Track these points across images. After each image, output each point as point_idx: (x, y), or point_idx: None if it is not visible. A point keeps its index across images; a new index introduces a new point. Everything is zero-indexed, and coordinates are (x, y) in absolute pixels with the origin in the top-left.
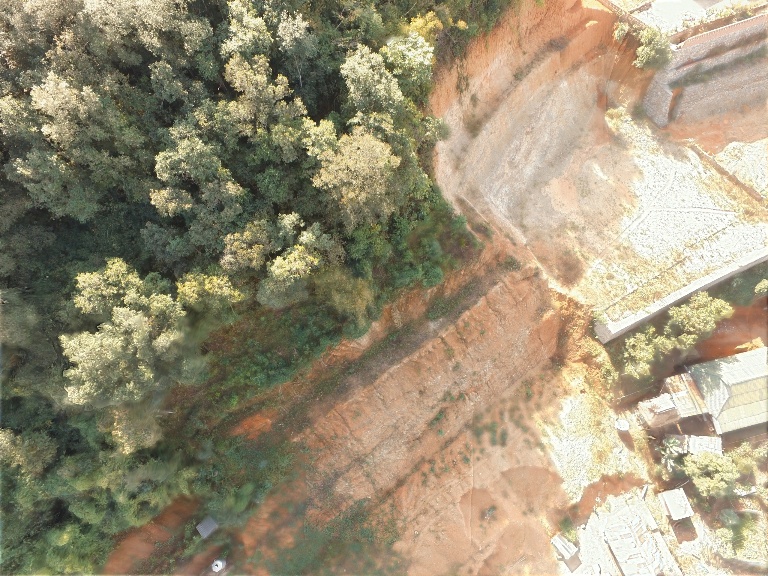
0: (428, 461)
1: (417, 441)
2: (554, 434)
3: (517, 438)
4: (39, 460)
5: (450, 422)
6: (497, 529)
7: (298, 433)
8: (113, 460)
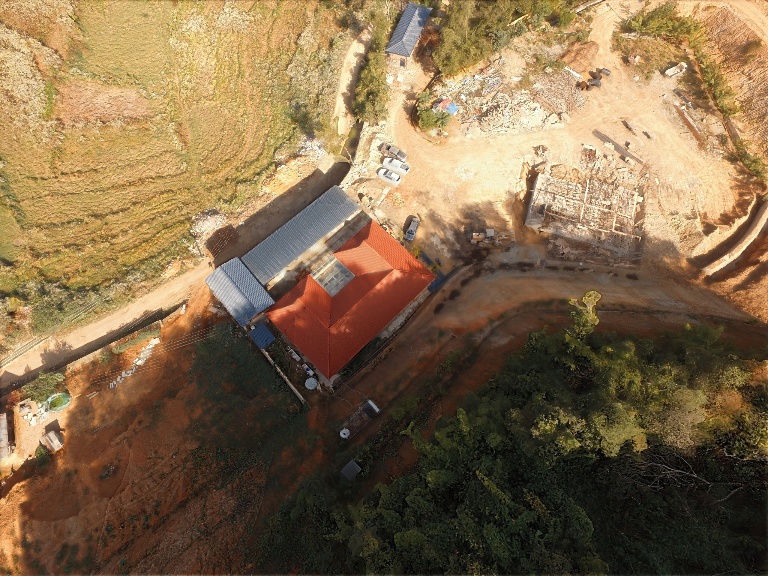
0: (150, 527)
1: (148, 553)
2: (6, 558)
3: (47, 553)
4: (454, 569)
5: (110, 575)
6: (105, 458)
7: (246, 574)
8: (378, 567)
